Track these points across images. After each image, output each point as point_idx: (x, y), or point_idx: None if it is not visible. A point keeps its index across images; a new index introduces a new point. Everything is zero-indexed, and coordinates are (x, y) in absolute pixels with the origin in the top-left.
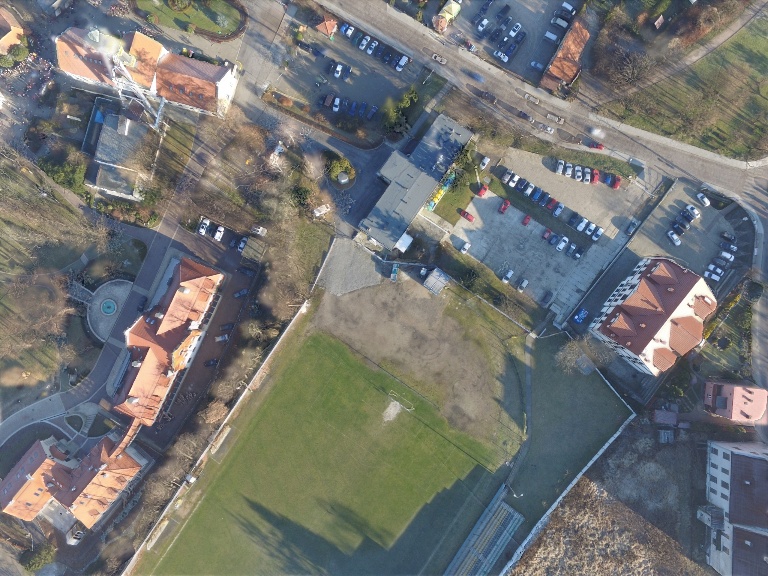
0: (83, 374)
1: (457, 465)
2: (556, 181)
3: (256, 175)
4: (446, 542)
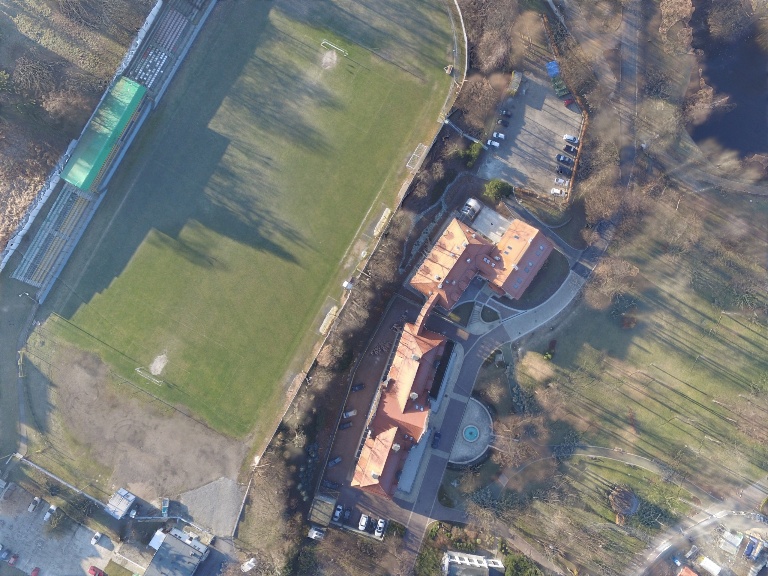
0: (488, 363)
1: (89, 317)
2: None
3: None
4: (96, 241)
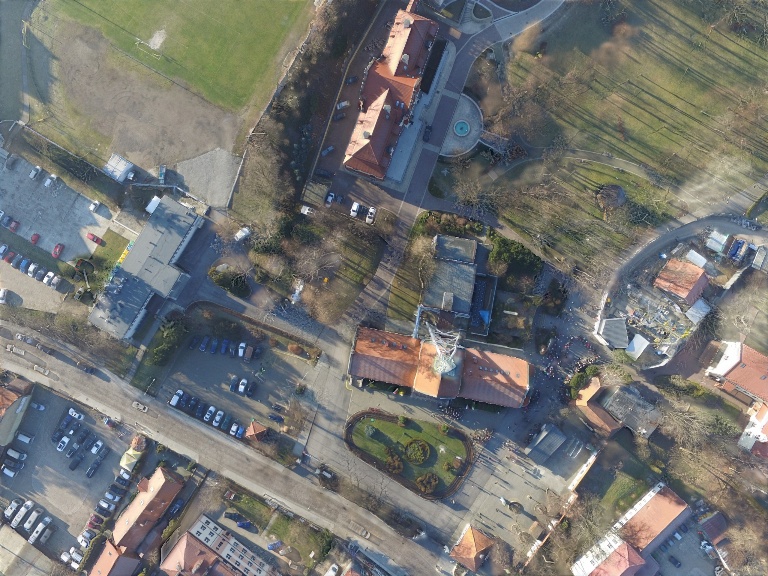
0: (480, 60)
1: None
2: (7, 282)
3: (316, 267)
4: None
